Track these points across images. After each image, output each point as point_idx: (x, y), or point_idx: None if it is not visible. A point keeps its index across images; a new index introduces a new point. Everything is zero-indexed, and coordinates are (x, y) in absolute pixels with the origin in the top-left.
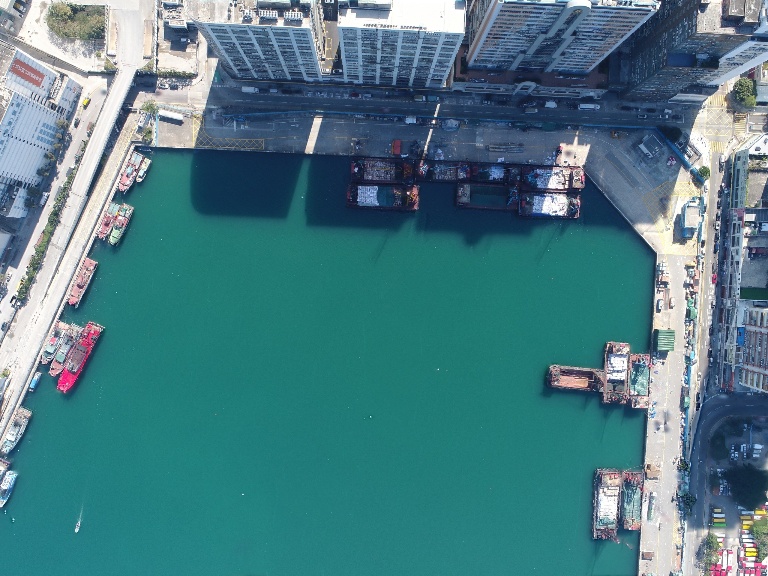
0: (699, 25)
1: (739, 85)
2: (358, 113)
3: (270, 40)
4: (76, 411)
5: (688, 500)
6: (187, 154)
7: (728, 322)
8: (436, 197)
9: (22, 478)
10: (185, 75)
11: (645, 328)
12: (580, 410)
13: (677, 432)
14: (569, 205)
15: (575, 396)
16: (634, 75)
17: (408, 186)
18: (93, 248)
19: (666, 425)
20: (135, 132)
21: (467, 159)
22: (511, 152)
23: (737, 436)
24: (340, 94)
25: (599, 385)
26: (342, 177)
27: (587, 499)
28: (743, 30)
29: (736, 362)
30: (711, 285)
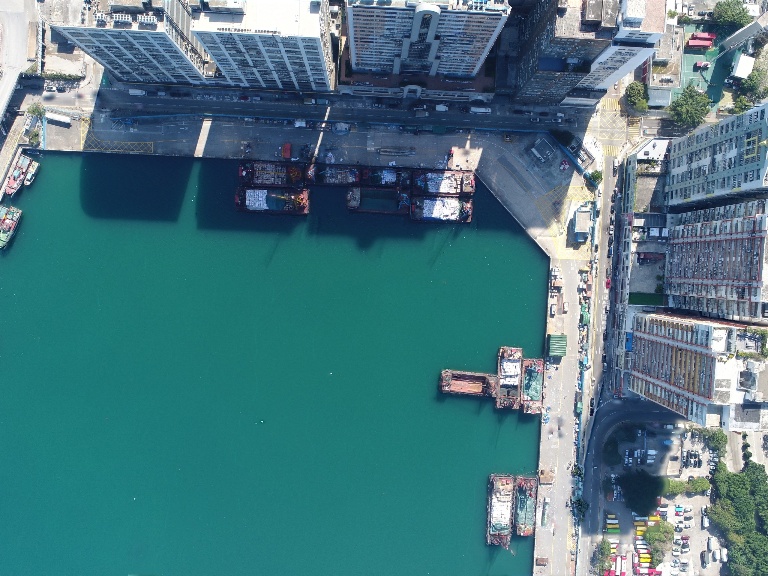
0: (558, 30)
1: (630, 89)
2: (247, 116)
3: (133, 44)
4: None
5: (580, 506)
6: (76, 157)
7: (619, 327)
8: (328, 201)
9: None
10: (71, 78)
11: (540, 333)
12: (474, 415)
13: (571, 437)
14: (461, 209)
15: (469, 401)
16: (519, 79)
17: (298, 190)
18: None
19: (560, 430)
20: (22, 135)
21: (358, 163)
22: (402, 156)
23: (630, 442)
24: (229, 97)
25: (489, 390)
26: (233, 180)
27: (481, 504)
28: (603, 35)
29: (625, 368)
30: (605, 290)
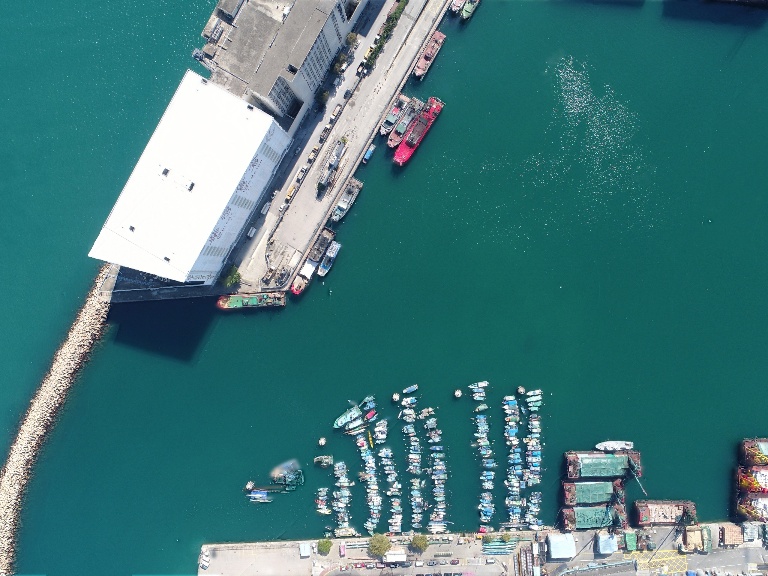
0: None
1: None
2: None
3: None
4: (406, 188)
5: None
6: None
7: None
8: None
9: (344, 251)
10: None
11: None
12: None
13: None
14: None
15: None
16: None
17: None
18: (441, 23)
19: None
20: None
21: None
22: None
23: None
24: None
25: None
26: None
27: None
28: None
29: None
30: None
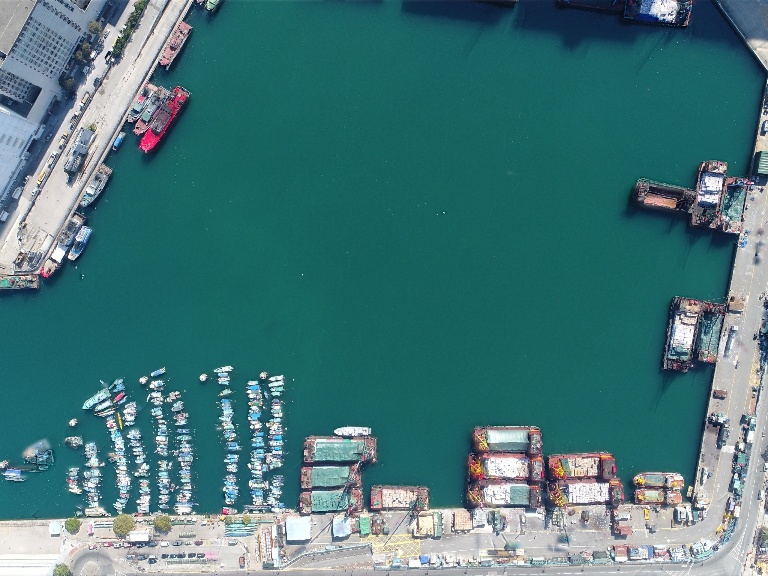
0: None
1: None
2: None
3: None
4: (154, 175)
5: None
6: None
7: None
8: None
9: (96, 236)
10: None
11: (745, 153)
12: (664, 232)
13: None
14: (679, 11)
15: (661, 216)
16: None
17: None
18: (189, 14)
19: (757, 256)
20: None
21: None
22: None
23: None
24: None
25: (690, 200)
26: None
27: (661, 327)
28: None
29: None
30: None
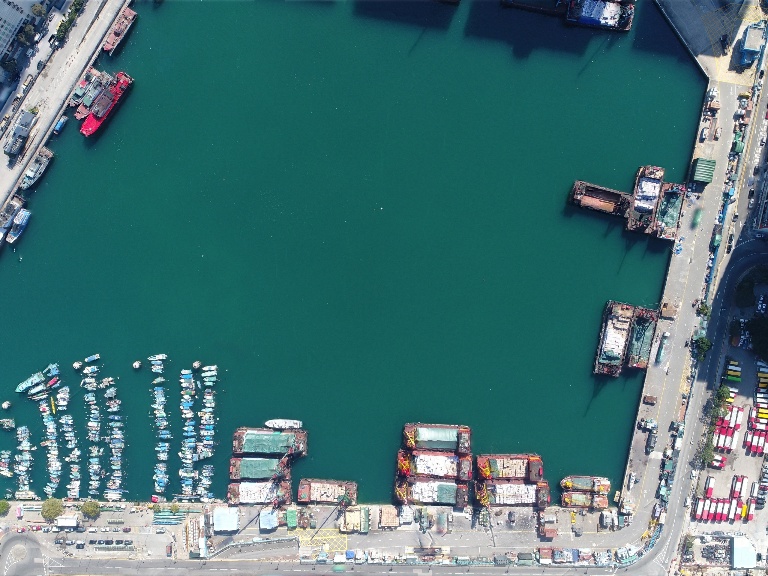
0: None
1: None
2: None
3: None
4: (95, 160)
5: (703, 343)
6: None
7: None
8: None
9: (35, 219)
10: None
11: (684, 159)
12: (601, 236)
13: (702, 273)
14: (622, 14)
15: (597, 220)
16: None
17: None
18: (135, 0)
19: (691, 263)
20: None
21: None
22: None
23: (767, 285)
24: None
25: (625, 204)
26: None
27: (594, 331)
28: None
29: None
30: (764, 121)
